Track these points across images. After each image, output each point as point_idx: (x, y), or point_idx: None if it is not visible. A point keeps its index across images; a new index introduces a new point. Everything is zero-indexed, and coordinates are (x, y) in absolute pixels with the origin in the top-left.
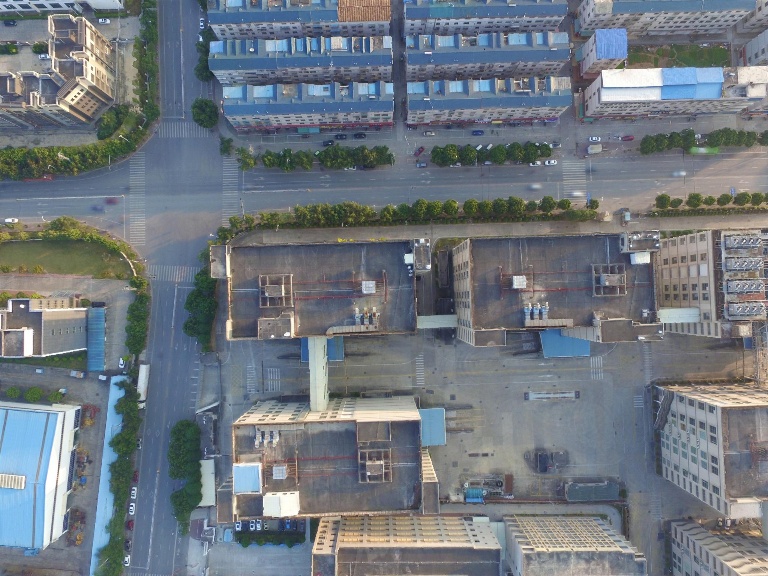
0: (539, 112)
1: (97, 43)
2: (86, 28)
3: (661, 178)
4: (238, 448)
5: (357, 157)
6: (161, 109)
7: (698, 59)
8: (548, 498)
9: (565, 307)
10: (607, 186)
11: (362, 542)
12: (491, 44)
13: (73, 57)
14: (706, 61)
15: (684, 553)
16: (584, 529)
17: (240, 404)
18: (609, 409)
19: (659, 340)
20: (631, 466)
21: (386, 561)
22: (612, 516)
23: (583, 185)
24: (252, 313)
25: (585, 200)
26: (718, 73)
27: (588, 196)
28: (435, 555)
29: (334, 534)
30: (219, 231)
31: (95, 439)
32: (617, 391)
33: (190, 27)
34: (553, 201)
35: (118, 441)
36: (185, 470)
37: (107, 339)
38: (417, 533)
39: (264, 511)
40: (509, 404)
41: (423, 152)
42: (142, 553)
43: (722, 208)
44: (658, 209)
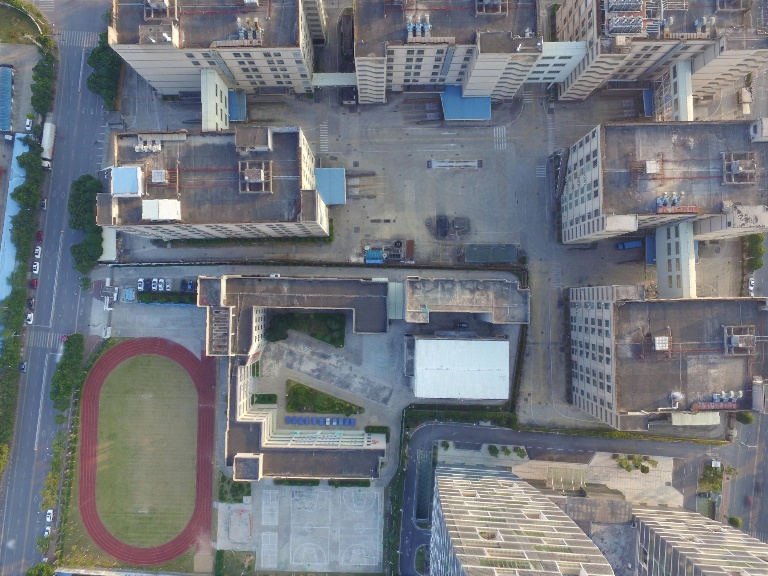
0: None
1: None
2: None
3: None
4: (121, 158)
5: None
6: None
7: None
8: (449, 264)
9: (448, 27)
10: None
11: None
12: None
13: None
14: None
15: (578, 308)
16: None
17: None
18: (511, 178)
19: (538, 53)
20: (532, 234)
21: (274, 293)
22: None
23: None
24: (137, 27)
25: None
26: None
27: None
28: (323, 288)
29: None
30: None
31: (1, 200)
32: (520, 161)
33: None
34: None
35: (19, 190)
36: (84, 218)
37: (14, 102)
38: None
39: (143, 214)
40: (412, 172)
41: None
42: (45, 312)
43: None
44: None
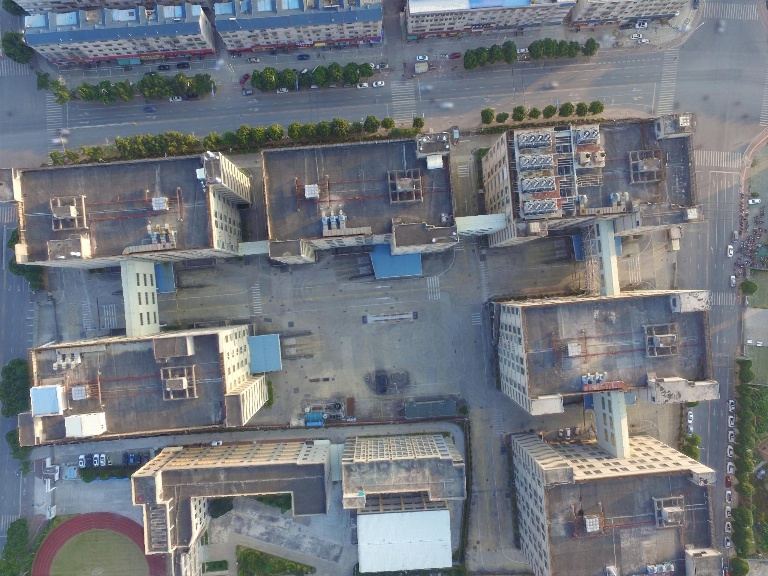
0: (356, 30)
1: None
2: None
3: (490, 95)
4: (41, 373)
5: (174, 85)
6: None
7: None
8: (390, 419)
9: (364, 216)
10: (437, 105)
11: (188, 465)
12: None
13: None
14: None
15: (518, 462)
16: (417, 443)
17: None
18: (447, 328)
19: (454, 242)
20: (471, 383)
21: (211, 482)
22: (455, 433)
23: (412, 105)
24: (47, 237)
25: None
26: None
27: (412, 114)
28: (260, 473)
29: (166, 461)
30: None
31: None
32: (455, 310)
33: None
34: (375, 120)
35: None
36: (17, 407)
37: None
38: (249, 456)
39: (66, 432)
40: (348, 328)
41: (249, 79)
42: None
43: (552, 122)
44: (488, 126)
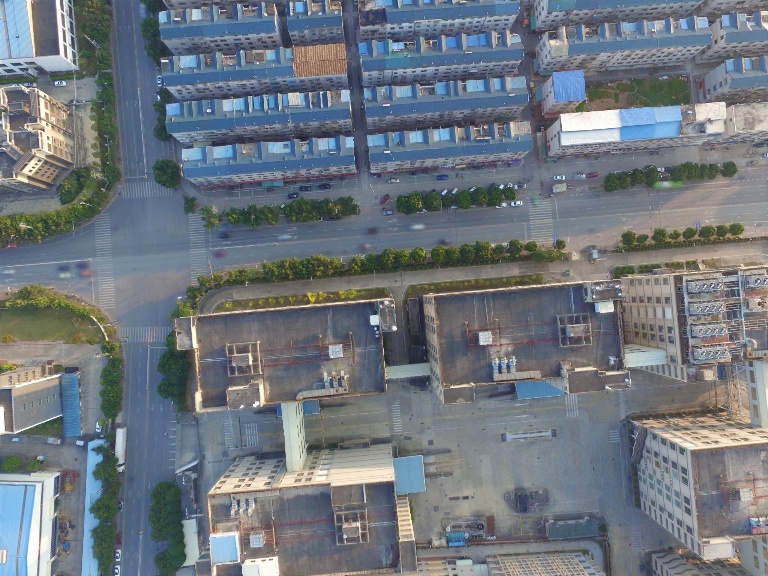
0: (501, 156)
1: (52, 111)
2: (39, 98)
3: (627, 213)
4: (215, 517)
5: (322, 210)
6: (123, 170)
7: (658, 92)
8: (530, 537)
9: (532, 359)
10: (574, 224)
11: None
12: (449, 92)
13: (28, 129)
14: (666, 94)
15: None
16: (565, 568)
17: (219, 461)
18: (586, 445)
19: None
20: (610, 500)
21: None
22: (594, 551)
23: (550, 224)
24: (221, 382)
25: (552, 239)
26: (676, 111)
27: (554, 237)
28: None
29: None
30: (188, 291)
31: (76, 504)
32: (593, 427)
33: (148, 85)
34: (520, 244)
35: (98, 507)
36: (167, 533)
37: (82, 404)
38: None
39: None
40: (487, 446)
41: (389, 199)
42: None
43: (688, 240)
44: (625, 244)
